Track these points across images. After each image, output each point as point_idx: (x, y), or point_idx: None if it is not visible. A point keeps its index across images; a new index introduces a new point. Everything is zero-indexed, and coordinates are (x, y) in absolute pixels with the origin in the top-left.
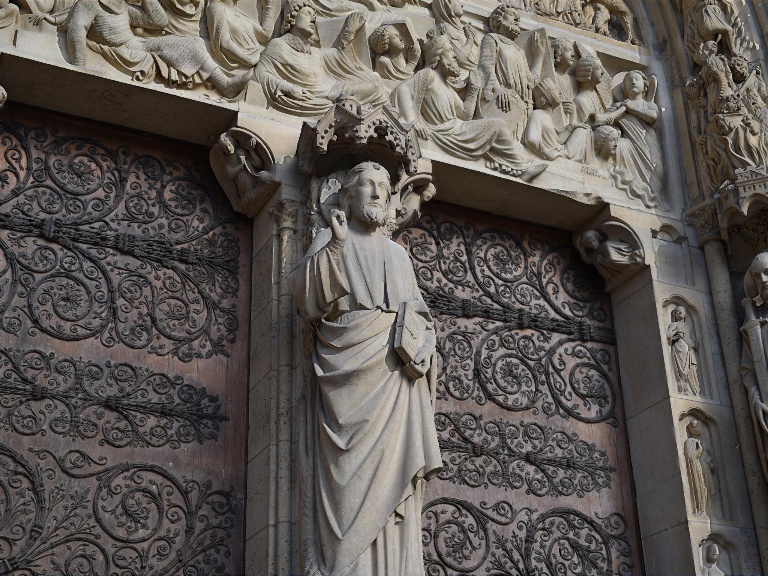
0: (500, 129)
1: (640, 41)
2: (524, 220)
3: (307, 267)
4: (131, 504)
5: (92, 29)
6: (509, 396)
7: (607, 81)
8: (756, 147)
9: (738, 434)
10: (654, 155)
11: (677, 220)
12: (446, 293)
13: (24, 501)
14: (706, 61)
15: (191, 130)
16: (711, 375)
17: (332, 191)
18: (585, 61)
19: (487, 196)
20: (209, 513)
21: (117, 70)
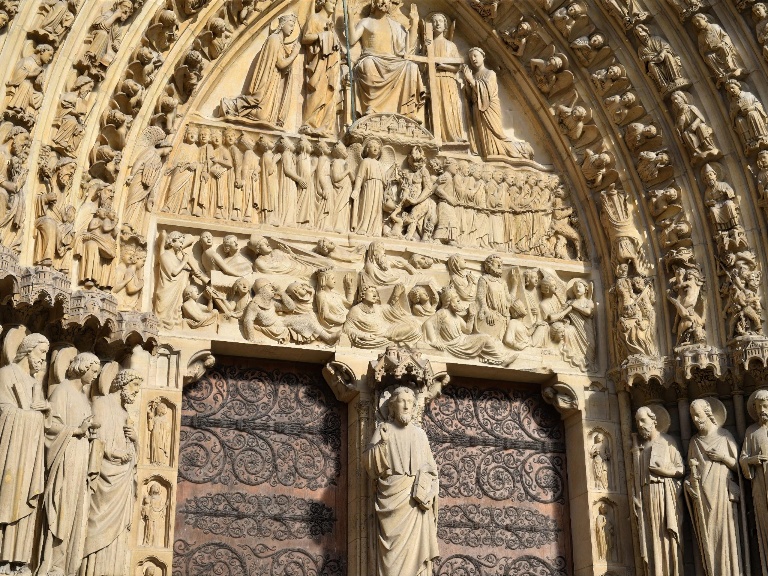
0: (487, 340)
1: (586, 257)
2: (510, 381)
3: (370, 454)
4: (289, 570)
5: (256, 320)
6: (497, 492)
7: (562, 288)
8: (643, 339)
9: (630, 511)
10: (589, 337)
11: (602, 378)
12: (460, 433)
13: (238, 572)
14: (617, 282)
15: (312, 359)
16: (616, 475)
17: (386, 399)
18: (545, 282)
19: (484, 373)
20: (329, 572)
21: (270, 339)
